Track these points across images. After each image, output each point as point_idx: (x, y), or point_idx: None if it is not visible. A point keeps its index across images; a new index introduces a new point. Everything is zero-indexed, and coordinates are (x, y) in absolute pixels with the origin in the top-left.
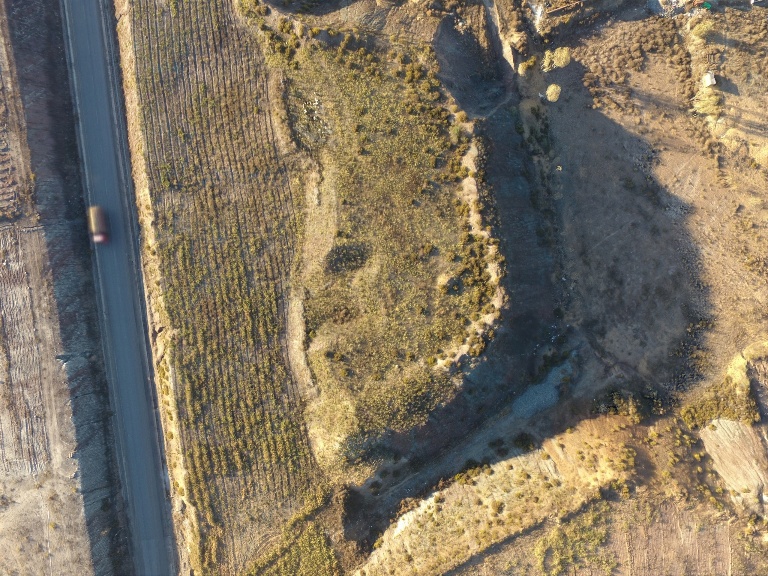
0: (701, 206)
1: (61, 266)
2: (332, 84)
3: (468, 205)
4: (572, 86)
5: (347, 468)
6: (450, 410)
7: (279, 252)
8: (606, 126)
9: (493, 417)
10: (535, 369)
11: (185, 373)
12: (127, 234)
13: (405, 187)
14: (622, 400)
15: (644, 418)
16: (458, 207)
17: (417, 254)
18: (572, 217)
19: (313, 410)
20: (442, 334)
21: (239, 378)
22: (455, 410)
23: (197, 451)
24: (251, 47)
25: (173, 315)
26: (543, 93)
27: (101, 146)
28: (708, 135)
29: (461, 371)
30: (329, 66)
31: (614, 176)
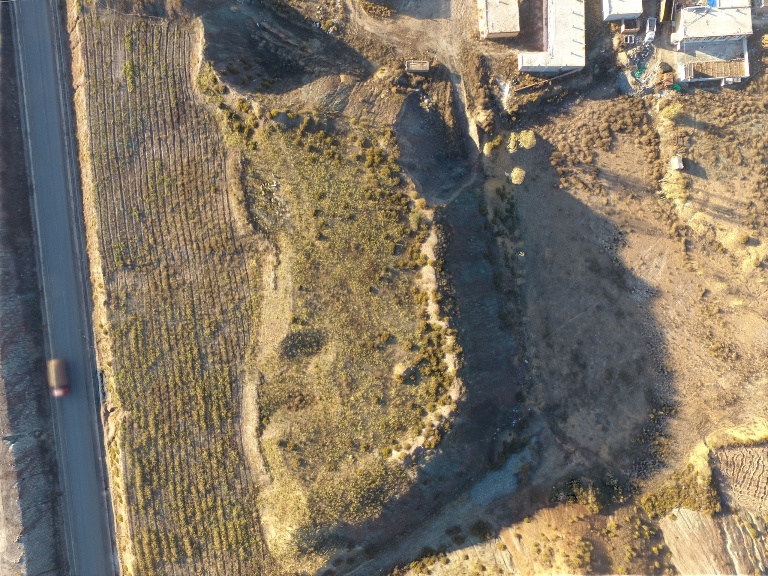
0: (667, 290)
1: (11, 344)
2: (290, 167)
3: (427, 294)
4: (539, 165)
5: (299, 557)
6: (405, 501)
7: (234, 335)
8: (573, 206)
9: (450, 503)
10: (494, 454)
11: (135, 457)
12: (81, 310)
13: (363, 274)
14: (581, 489)
15: (603, 507)
16: (416, 295)
17: (374, 342)
18: (536, 298)
19: (266, 497)
20: (397, 425)
21: (191, 463)
22: (410, 500)
23: (146, 537)
24: (209, 125)
25: (124, 397)
26: (509, 171)
27: (56, 219)
28: (675, 218)
29: (416, 463)
30: (288, 148)
31: (580, 257)
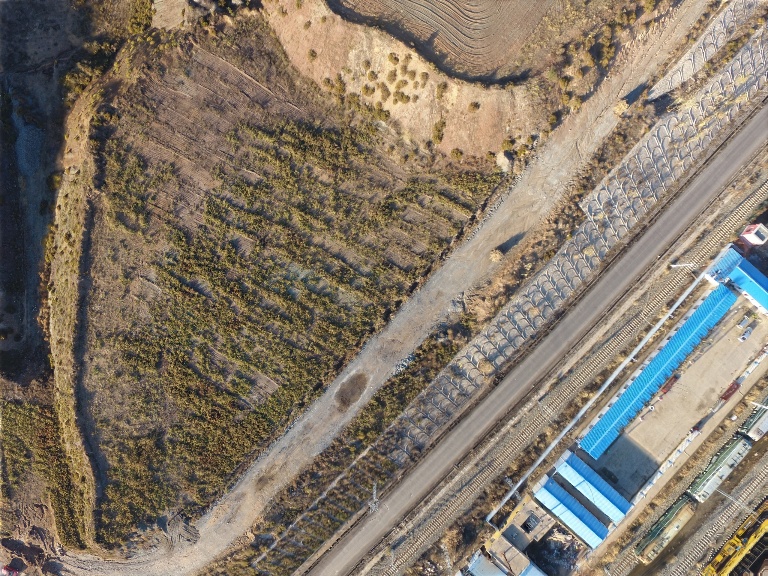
0: None
1: None
2: None
3: None
4: None
5: None
6: None
7: None
8: None
9: (21, 196)
10: None
11: None
12: None
13: None
14: (75, 75)
15: (103, 66)
16: None
17: None
18: None
19: None
20: None
21: None
22: None
23: None
24: None
25: None
26: None
27: None
28: None
29: None
30: None
31: None
